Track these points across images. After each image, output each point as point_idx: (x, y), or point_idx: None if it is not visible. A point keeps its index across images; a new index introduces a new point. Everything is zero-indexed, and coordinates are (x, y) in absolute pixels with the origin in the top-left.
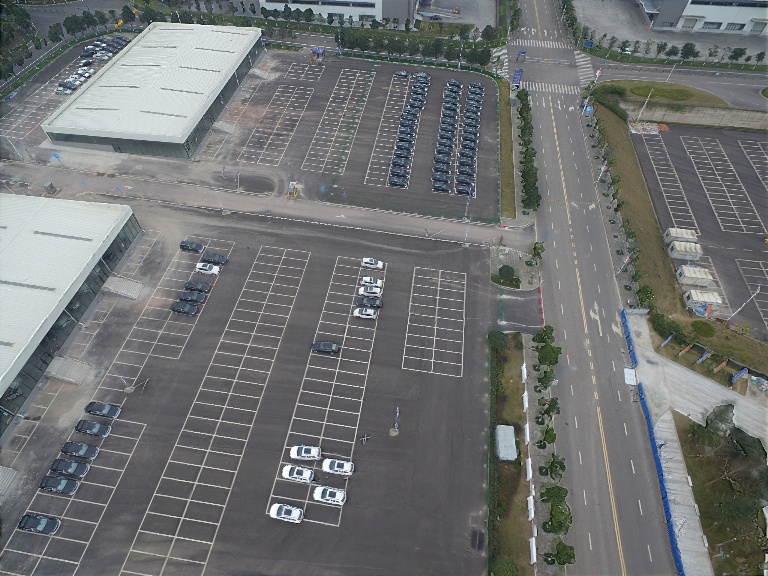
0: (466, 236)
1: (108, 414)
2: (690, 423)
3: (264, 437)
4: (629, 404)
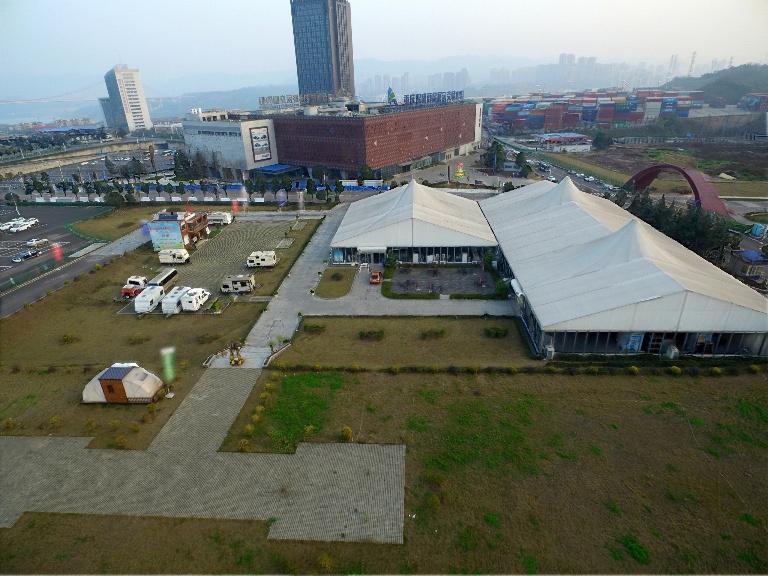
0: None
1: None
2: None
3: None
4: None
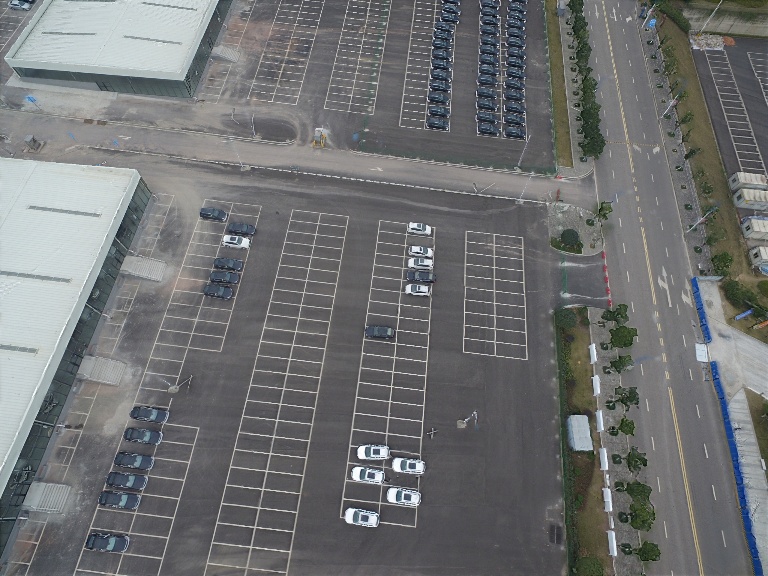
0: (521, 192)
1: (156, 420)
2: (763, 402)
3: (327, 436)
4: (701, 383)
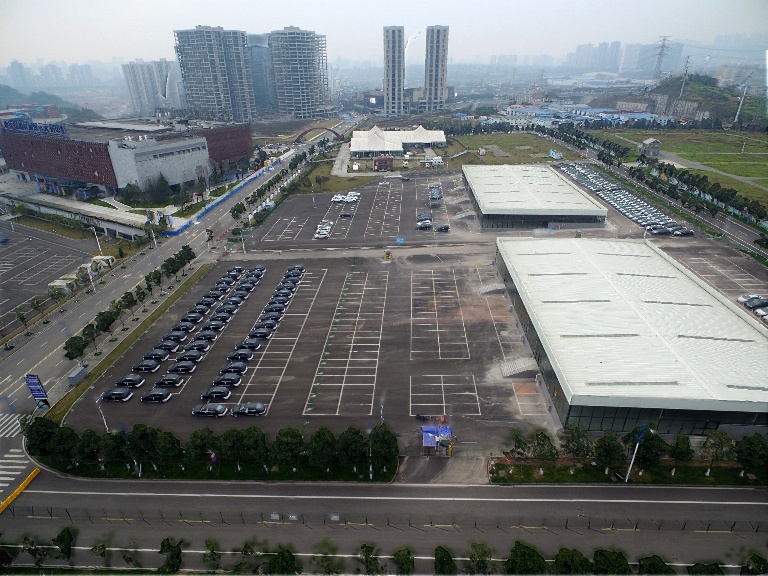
0: None
1: None
2: None
3: None
4: None
